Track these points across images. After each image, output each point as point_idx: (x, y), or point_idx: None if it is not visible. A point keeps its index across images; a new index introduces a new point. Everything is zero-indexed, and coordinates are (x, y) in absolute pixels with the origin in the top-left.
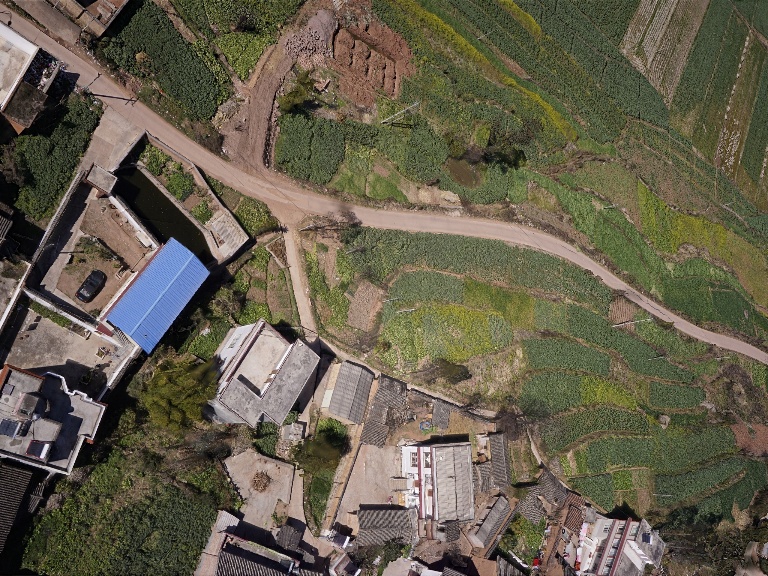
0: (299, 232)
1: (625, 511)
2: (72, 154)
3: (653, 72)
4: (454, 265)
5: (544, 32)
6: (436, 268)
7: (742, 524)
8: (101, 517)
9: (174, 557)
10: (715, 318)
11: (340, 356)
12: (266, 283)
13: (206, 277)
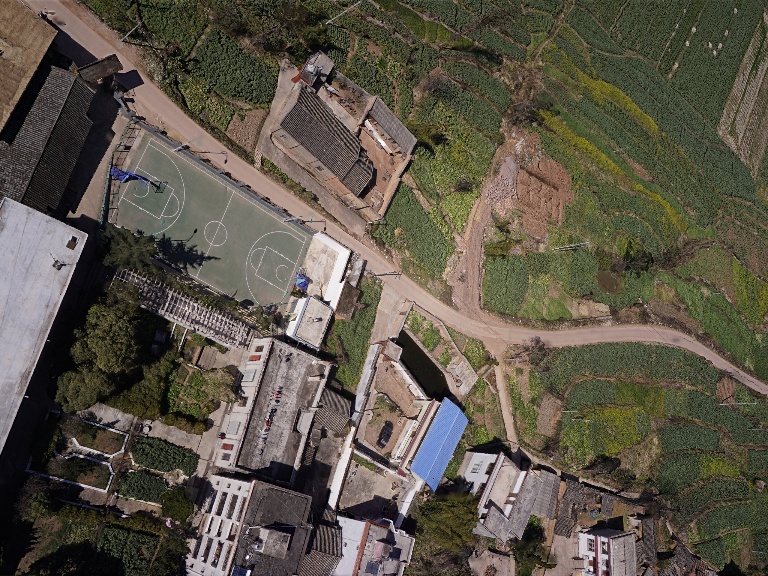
0: (504, 361)
1: (732, 567)
2: (367, 329)
3: (743, 148)
4: (608, 370)
5: (659, 129)
6: (595, 374)
7: None
8: None
9: None
10: None
11: (533, 461)
12: (484, 407)
13: None
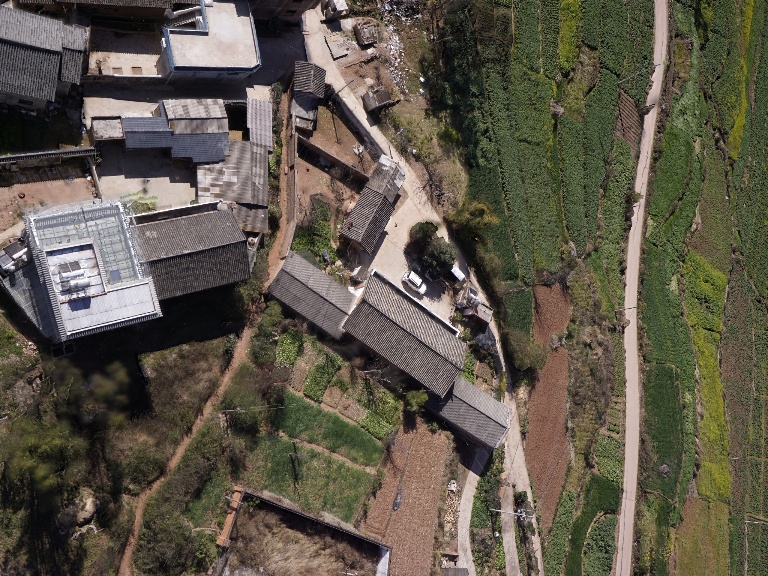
0: None
1: None
2: None
3: None
4: None
5: None
6: None
7: None
8: None
9: None
10: None
11: None
12: None
13: None
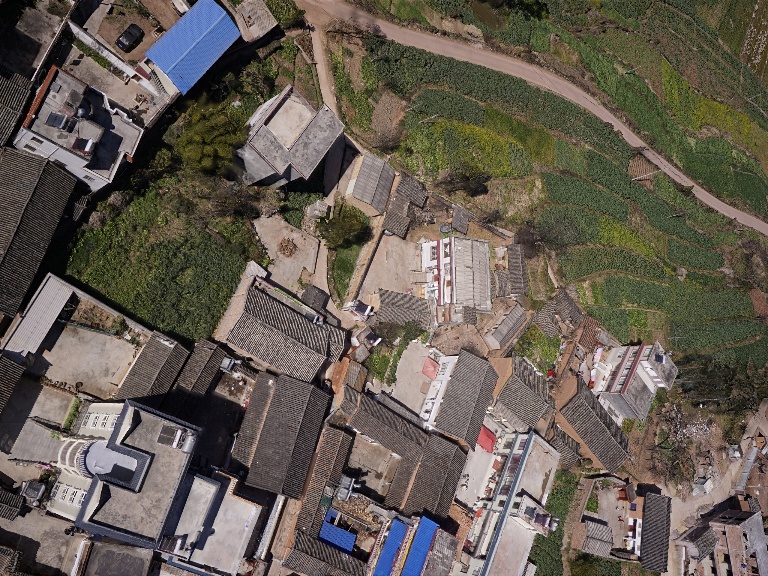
0: (326, 33)
1: None
2: None
3: None
4: (476, 92)
5: None
6: (458, 92)
7: (757, 382)
8: (139, 245)
9: (206, 294)
10: (736, 196)
11: (364, 154)
12: (294, 75)
13: (237, 37)
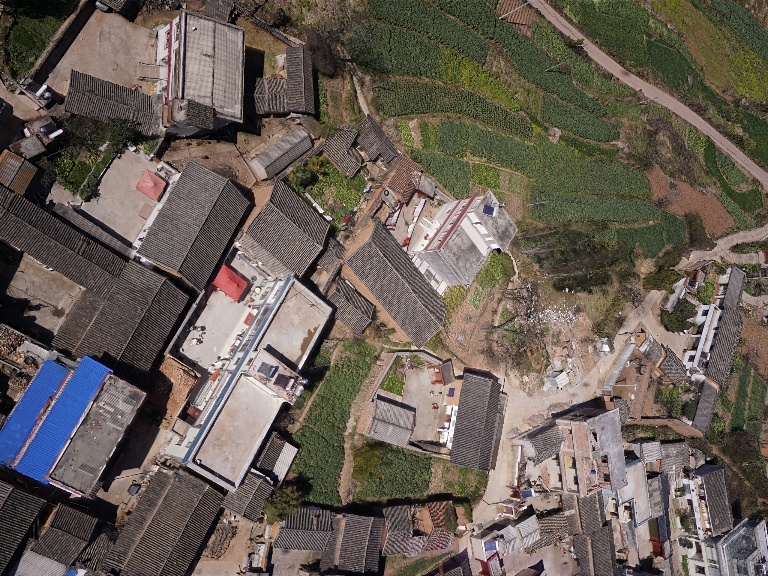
0: None
1: None
2: None
3: None
4: None
5: None
6: None
7: (644, 272)
8: None
9: None
10: None
11: None
12: None
13: None
